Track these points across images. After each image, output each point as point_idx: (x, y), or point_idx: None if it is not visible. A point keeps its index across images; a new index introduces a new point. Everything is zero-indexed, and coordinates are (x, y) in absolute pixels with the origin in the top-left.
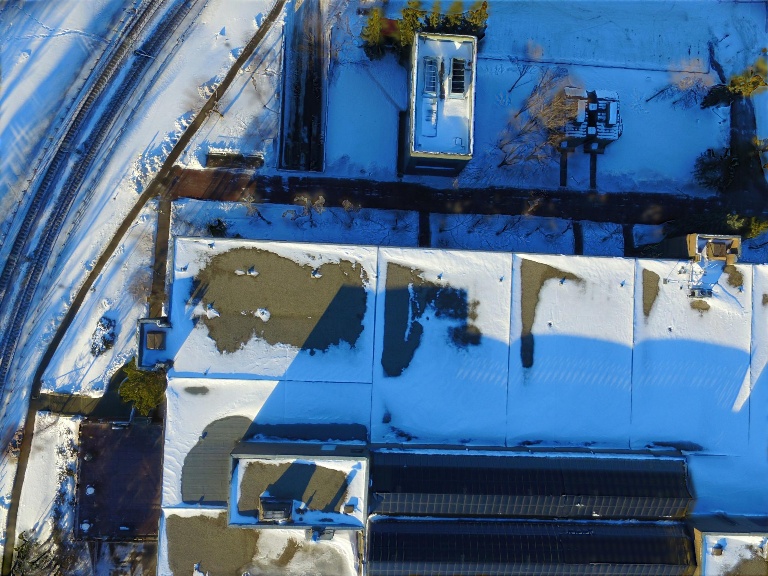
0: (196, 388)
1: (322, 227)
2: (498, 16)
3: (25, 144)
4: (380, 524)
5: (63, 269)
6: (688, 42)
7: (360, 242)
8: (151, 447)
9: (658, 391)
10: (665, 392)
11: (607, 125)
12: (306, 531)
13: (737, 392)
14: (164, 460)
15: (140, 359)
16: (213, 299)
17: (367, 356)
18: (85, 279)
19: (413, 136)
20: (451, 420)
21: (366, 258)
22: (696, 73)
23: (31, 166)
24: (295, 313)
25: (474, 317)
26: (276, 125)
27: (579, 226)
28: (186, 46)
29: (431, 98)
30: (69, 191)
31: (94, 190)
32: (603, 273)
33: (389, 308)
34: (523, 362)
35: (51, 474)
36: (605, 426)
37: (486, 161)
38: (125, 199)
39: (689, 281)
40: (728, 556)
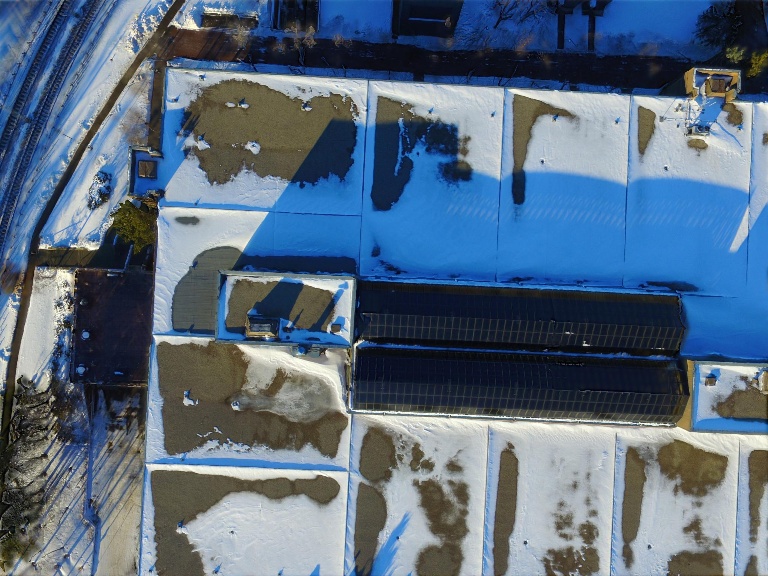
0: (187, 218)
1: None
2: None
3: (25, 6)
4: (368, 351)
5: (61, 130)
6: None
7: None
8: (145, 295)
9: (653, 230)
10: (660, 231)
11: None
12: (293, 348)
13: (735, 232)
14: (155, 288)
15: (132, 186)
16: (204, 131)
17: (357, 189)
18: (82, 138)
19: None
20: (441, 255)
21: (356, 91)
22: None
23: (31, 29)
24: (285, 146)
25: (465, 153)
26: None
27: (576, 89)
28: None
29: None
30: (68, 54)
31: (92, 53)
32: (597, 110)
33: (379, 142)
34: (514, 199)
35: (49, 327)
36: (598, 264)
37: (482, 22)
38: (122, 59)
39: (686, 119)
40: (722, 387)
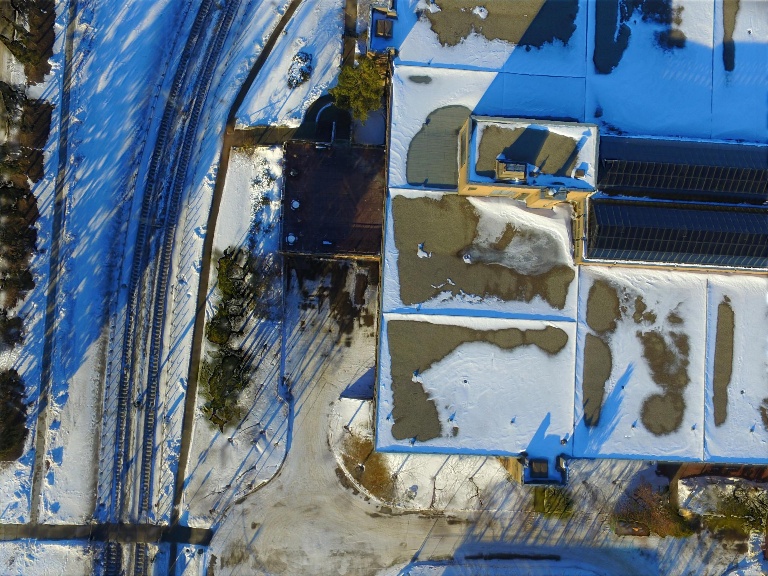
0: (420, 77)
1: None
2: None
3: None
4: (601, 201)
5: (254, 16)
6: None
7: None
8: (351, 168)
9: None
10: None
11: None
12: (541, 191)
13: None
14: (391, 143)
15: None
16: None
17: (580, 53)
18: (277, 23)
19: None
20: (659, 116)
21: None
22: None
23: None
24: (511, 11)
25: (679, 22)
26: None
27: None
28: None
29: None
30: None
31: None
32: None
33: (600, 9)
34: (725, 66)
35: (245, 206)
36: None
37: None
38: None
39: None
40: None
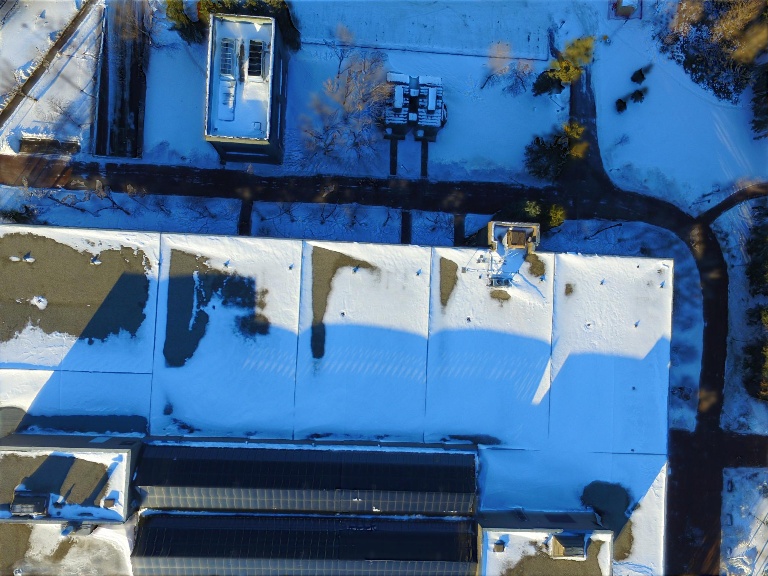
0: None
1: (136, 215)
2: (331, 1)
3: None
4: (151, 519)
5: None
6: (528, 29)
7: (177, 230)
8: None
9: (455, 383)
10: (462, 384)
11: (428, 111)
12: (62, 526)
13: (537, 384)
14: None
15: None
16: None
17: (148, 346)
18: None
19: (206, 120)
20: (236, 412)
21: (148, 244)
22: (535, 60)
23: None
24: (73, 301)
25: (262, 306)
26: (94, 110)
27: (409, 215)
28: (7, 29)
29: (229, 81)
30: None
31: None
32: (398, 261)
33: (172, 296)
34: (313, 353)
35: None
36: (398, 419)
37: (311, 148)
38: None
39: (489, 270)
40: (511, 553)
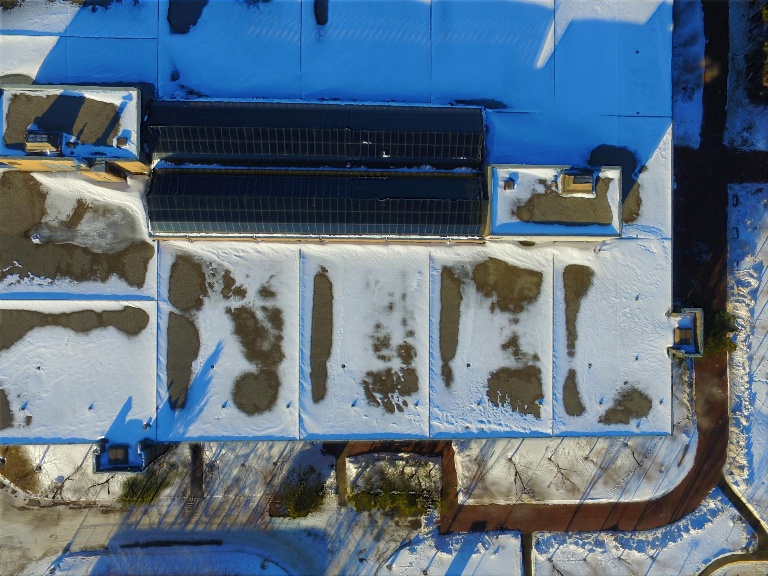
0: None
1: None
2: None
3: None
4: (165, 171)
5: None
6: None
7: None
8: None
9: (459, 48)
10: (467, 49)
11: None
12: None
13: (541, 48)
14: None
15: None
16: None
17: (152, 12)
18: None
19: None
20: (243, 77)
21: None
22: None
23: None
24: None
25: None
26: None
27: None
28: None
29: None
30: None
31: None
32: None
33: None
34: (317, 19)
35: None
36: (404, 83)
37: None
38: None
39: None
40: (521, 191)
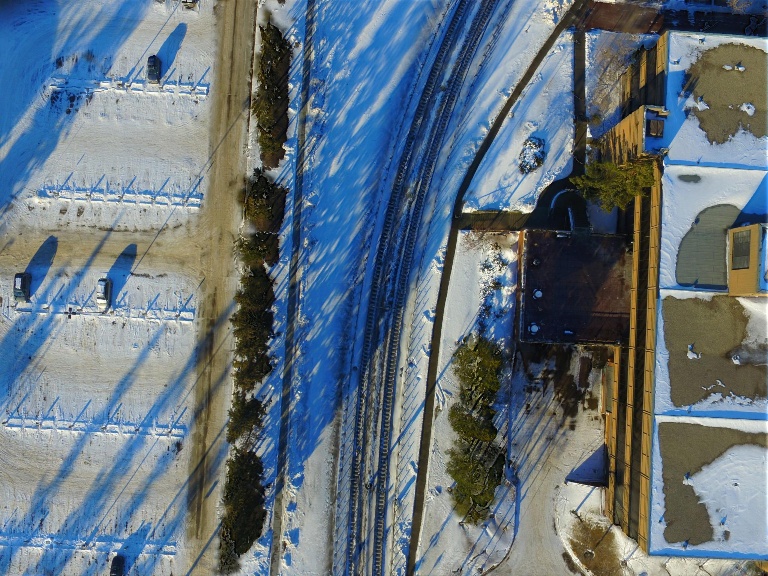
0: (689, 176)
1: None
2: None
3: None
4: None
5: (477, 98)
6: None
7: None
8: (590, 256)
9: None
10: None
11: None
12: None
13: None
14: (662, 243)
15: None
16: (702, 92)
17: None
18: (503, 105)
19: None
20: None
21: None
22: None
23: (445, 1)
24: None
25: None
26: None
27: None
28: None
29: None
30: (478, 26)
31: (503, 25)
32: None
33: None
34: None
35: (474, 289)
36: None
37: None
38: (540, 30)
39: None
40: None
